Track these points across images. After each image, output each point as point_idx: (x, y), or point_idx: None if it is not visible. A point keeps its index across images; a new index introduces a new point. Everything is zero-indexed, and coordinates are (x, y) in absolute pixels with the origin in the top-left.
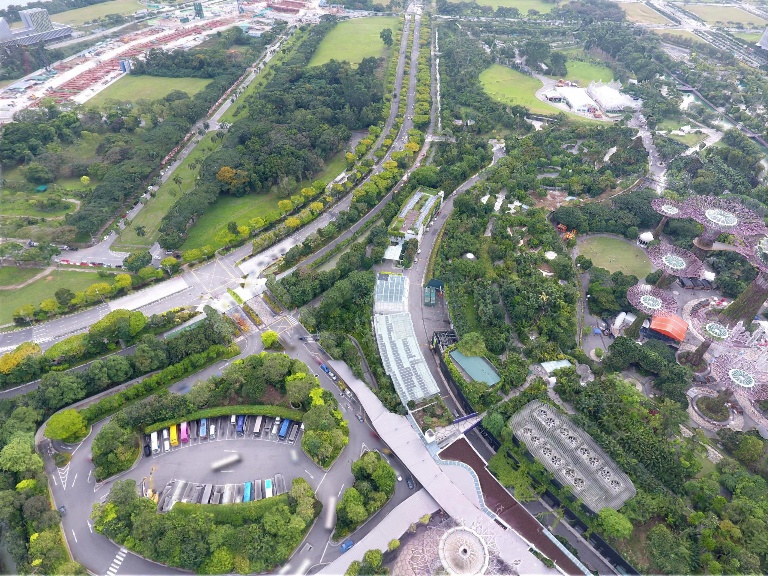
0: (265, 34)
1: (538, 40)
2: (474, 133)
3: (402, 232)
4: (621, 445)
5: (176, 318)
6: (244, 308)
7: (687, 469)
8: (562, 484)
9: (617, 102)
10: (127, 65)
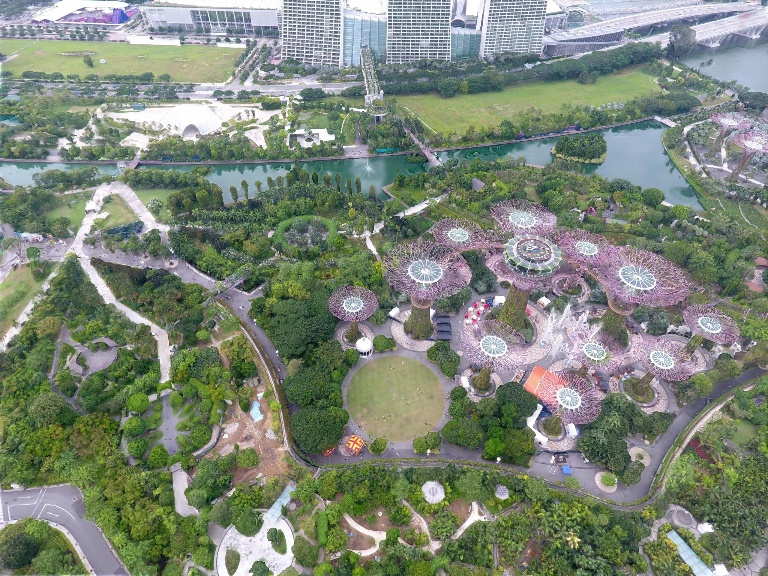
0: None
1: None
2: None
3: None
4: None
5: None
6: None
7: None
8: None
9: None
10: None
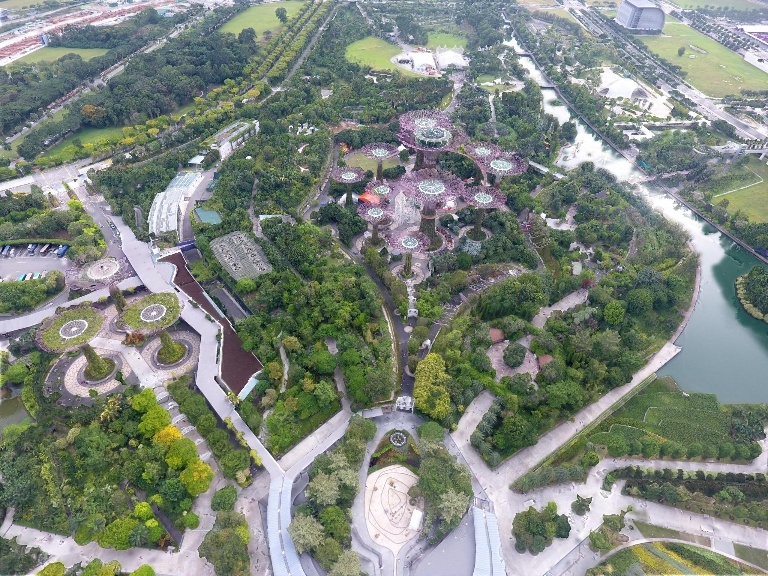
0: (177, 14)
1: (404, 14)
2: (317, 85)
3: (209, 146)
4: (282, 253)
5: (14, 196)
6: (68, 191)
7: (315, 262)
8: (225, 269)
9: (449, 62)
10: (46, 39)
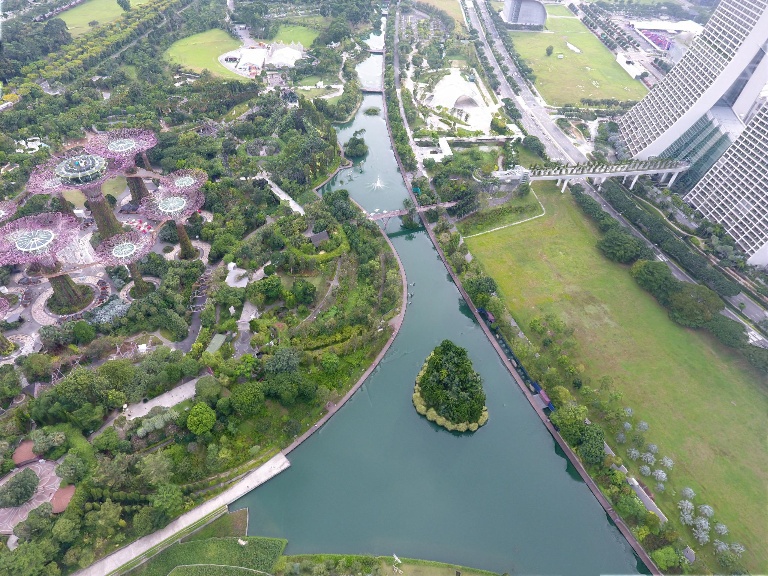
0: (7, 0)
1: None
2: (105, 88)
3: None
4: None
5: None
6: None
7: None
8: None
9: (273, 61)
10: None
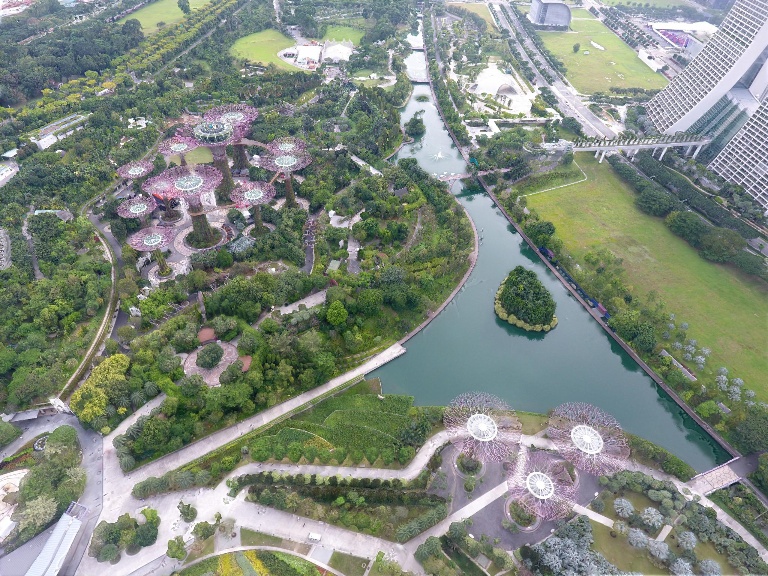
0: (78, 4)
1: (302, 7)
2: (185, 78)
3: (29, 139)
4: None
5: None
6: None
7: None
8: None
9: (330, 55)
10: None
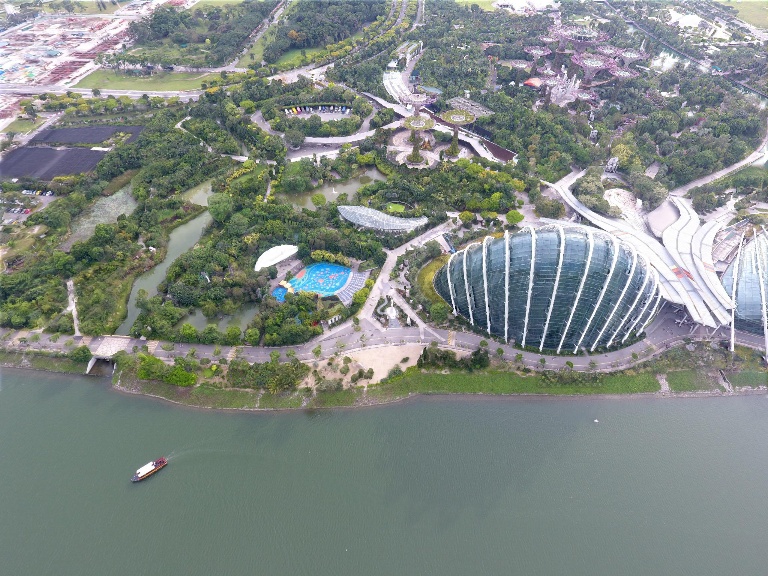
0: None
1: None
2: None
3: (398, 56)
4: None
5: (282, 84)
6: (316, 82)
7: None
8: None
9: (544, 4)
10: None
